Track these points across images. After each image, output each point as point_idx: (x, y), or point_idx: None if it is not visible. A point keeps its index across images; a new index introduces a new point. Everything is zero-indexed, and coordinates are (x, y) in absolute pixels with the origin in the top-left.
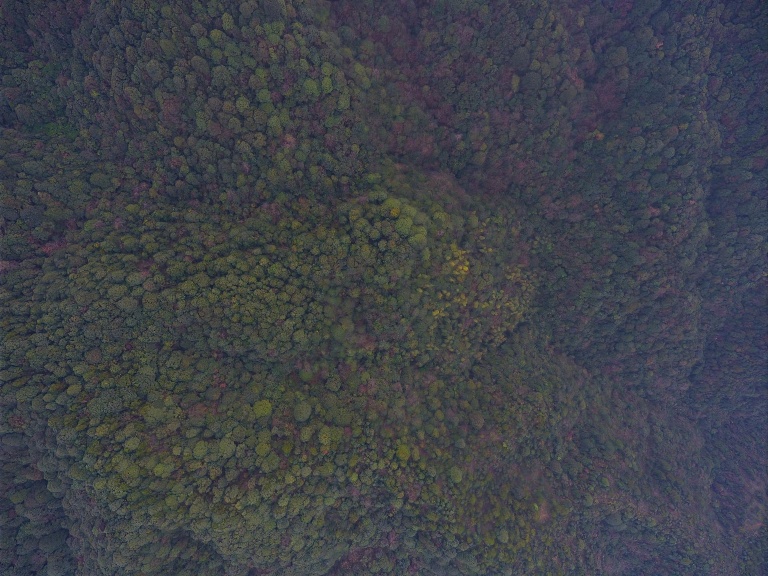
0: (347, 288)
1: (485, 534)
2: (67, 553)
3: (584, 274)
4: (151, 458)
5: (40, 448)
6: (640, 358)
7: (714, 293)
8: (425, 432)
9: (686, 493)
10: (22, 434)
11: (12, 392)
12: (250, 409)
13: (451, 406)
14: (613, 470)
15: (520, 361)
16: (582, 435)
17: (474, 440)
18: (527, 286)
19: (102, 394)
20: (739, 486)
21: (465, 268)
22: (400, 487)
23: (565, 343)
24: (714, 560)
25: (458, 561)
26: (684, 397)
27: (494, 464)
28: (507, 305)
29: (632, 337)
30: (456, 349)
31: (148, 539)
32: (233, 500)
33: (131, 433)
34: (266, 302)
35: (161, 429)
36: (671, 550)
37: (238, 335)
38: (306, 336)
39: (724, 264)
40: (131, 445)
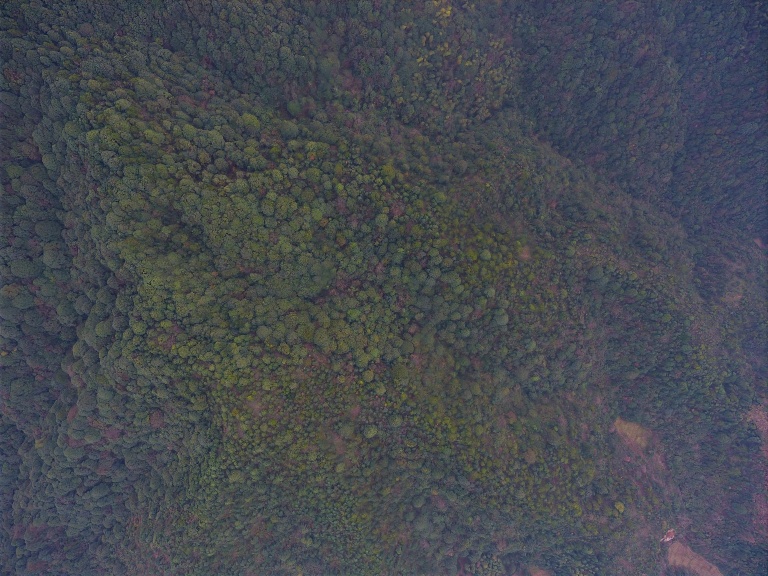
0: (333, 22)
1: (468, 250)
2: (62, 248)
3: (565, 45)
4: (142, 122)
5: (35, 107)
6: (622, 141)
7: (693, 71)
8: (410, 167)
9: (667, 257)
10: (18, 95)
11: (7, 38)
12: (239, 116)
13: (436, 156)
14: (595, 229)
15: (504, 129)
16: (565, 204)
17: (458, 179)
18: (510, 61)
19: (94, 57)
20: (720, 266)
21: (448, 12)
22: (385, 203)
23: (549, 129)
24: (695, 318)
25: (442, 282)
26: (667, 191)
27: (477, 203)
28: (491, 74)
29: (614, 114)
30: (440, 105)
31: (140, 204)
32: (222, 182)
33: (122, 94)
34: (253, 7)
35: (151, 102)
36: (652, 308)
37: (226, 39)
38: (293, 56)
39: (702, 34)
40: (122, 102)
